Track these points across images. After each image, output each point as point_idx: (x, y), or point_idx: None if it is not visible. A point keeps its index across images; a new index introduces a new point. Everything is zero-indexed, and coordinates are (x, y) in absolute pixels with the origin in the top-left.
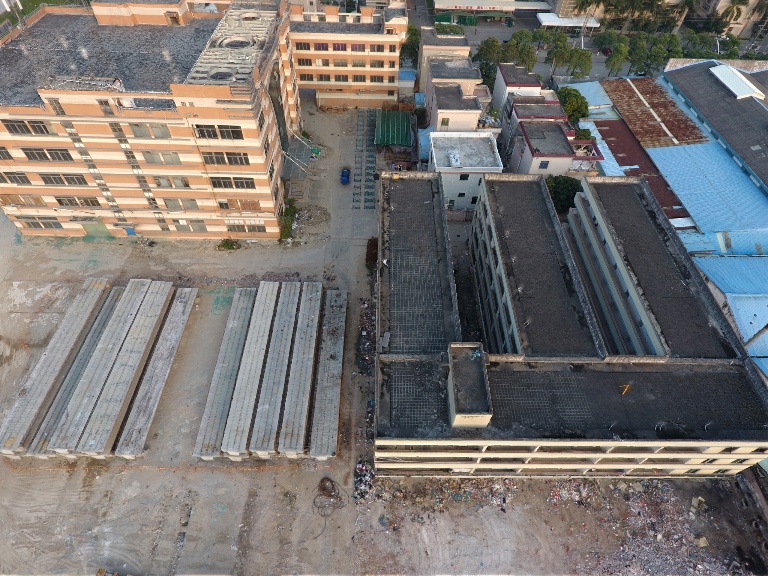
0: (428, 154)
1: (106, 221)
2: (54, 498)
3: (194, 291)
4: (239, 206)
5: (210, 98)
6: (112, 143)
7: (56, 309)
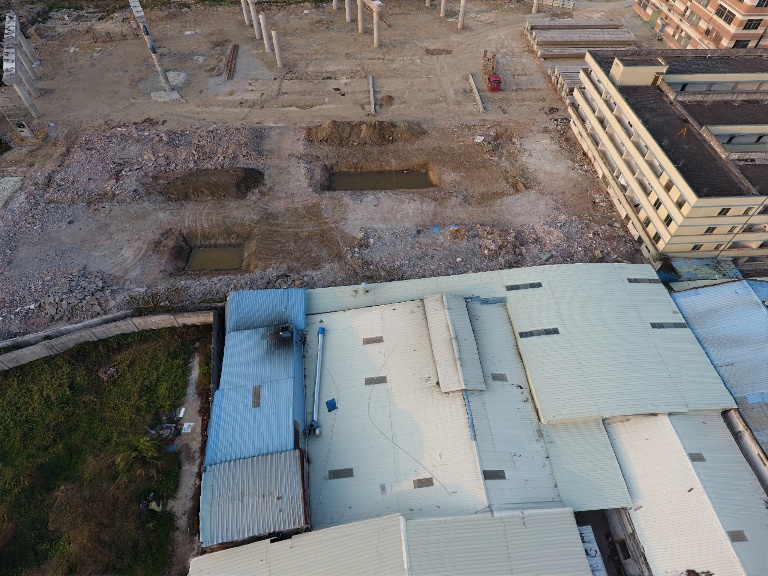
0: None
1: (661, 15)
2: (514, 46)
3: None
4: (713, 36)
5: None
6: None
7: None
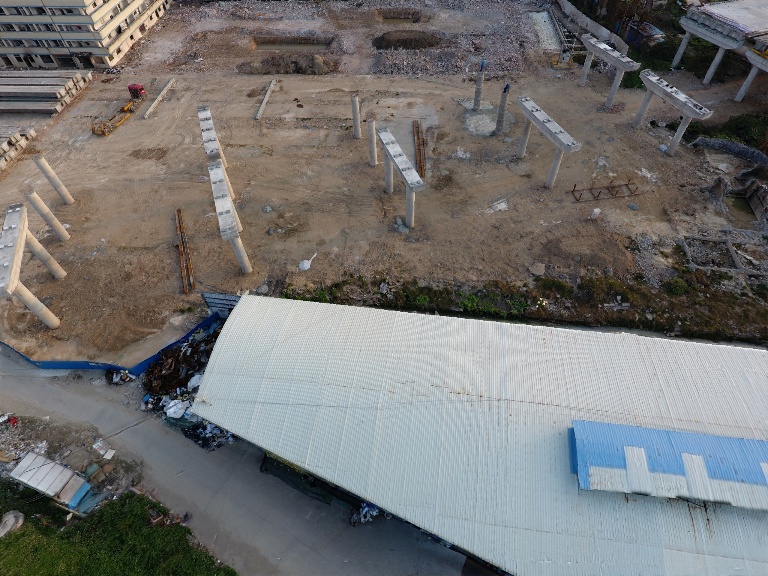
0: None
1: None
2: None
3: None
4: None
5: None
6: None
7: None
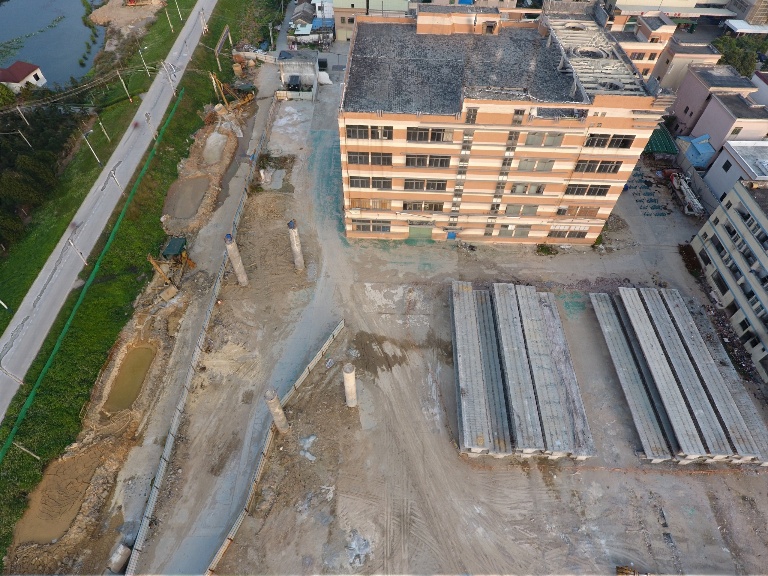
0: (704, 162)
1: (436, 225)
2: (526, 496)
3: (551, 295)
4: (576, 212)
5: (626, 108)
6: (498, 151)
7: (421, 311)
